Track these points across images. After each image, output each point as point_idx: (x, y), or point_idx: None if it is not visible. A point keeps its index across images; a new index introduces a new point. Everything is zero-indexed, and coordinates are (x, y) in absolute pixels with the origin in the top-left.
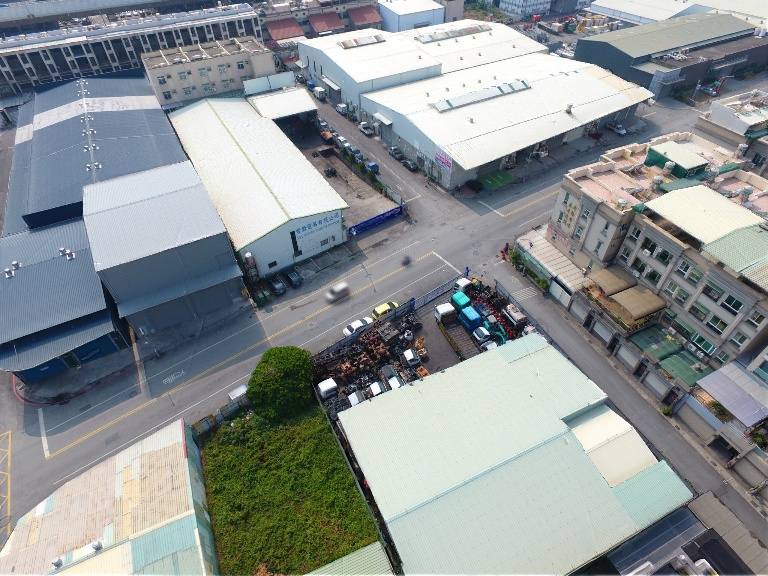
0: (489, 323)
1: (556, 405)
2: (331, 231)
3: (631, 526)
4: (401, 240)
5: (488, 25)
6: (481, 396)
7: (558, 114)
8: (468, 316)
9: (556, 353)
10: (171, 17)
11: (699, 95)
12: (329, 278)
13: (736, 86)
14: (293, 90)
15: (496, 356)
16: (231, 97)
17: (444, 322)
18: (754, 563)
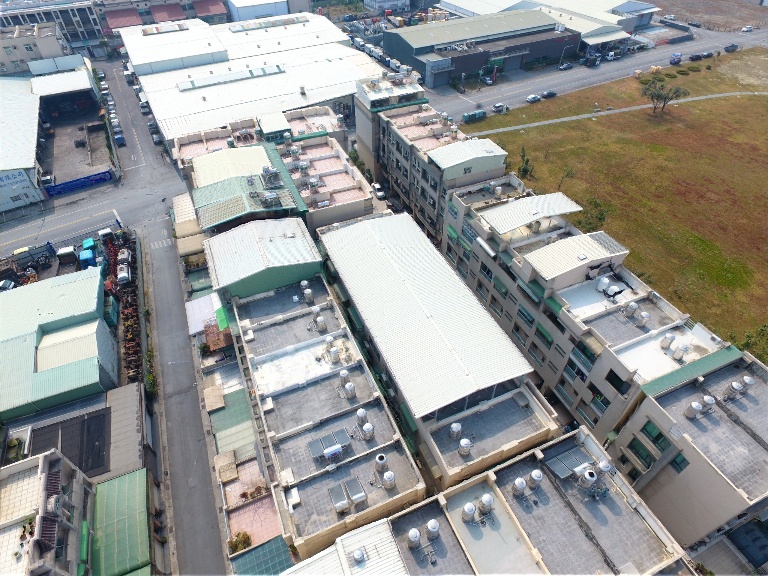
0: (100, 263)
1: (48, 316)
2: (20, 189)
3: (26, 399)
4: (95, 200)
5: (306, 17)
6: (4, 310)
7: (292, 95)
8: (80, 257)
9: (96, 280)
10: (5, 5)
11: None
12: (6, 228)
13: (520, 76)
14: (75, 71)
15: (48, 282)
16: (20, 76)
17: (63, 262)
18: (118, 430)
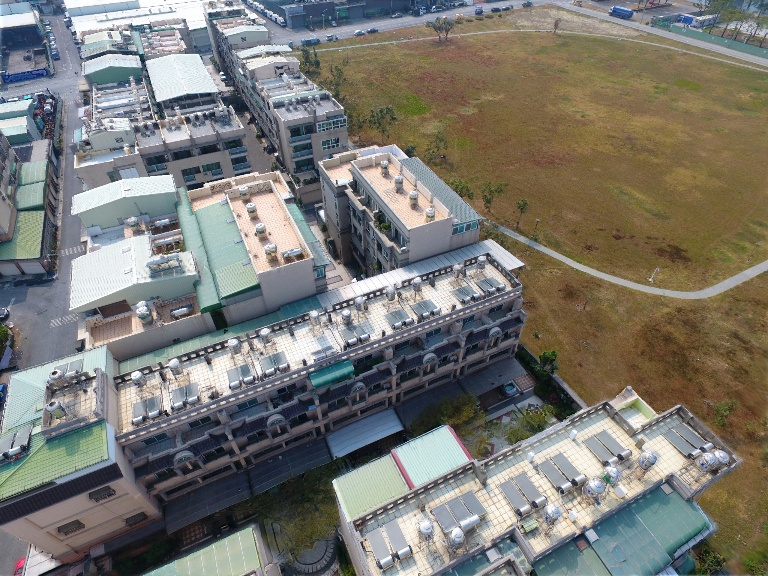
0: None
1: None
2: None
3: None
4: (36, 84)
5: None
6: None
7: None
8: None
9: (29, 102)
10: None
11: (326, 26)
12: None
13: (360, 22)
14: (24, 13)
15: None
16: None
17: None
18: (36, 151)
